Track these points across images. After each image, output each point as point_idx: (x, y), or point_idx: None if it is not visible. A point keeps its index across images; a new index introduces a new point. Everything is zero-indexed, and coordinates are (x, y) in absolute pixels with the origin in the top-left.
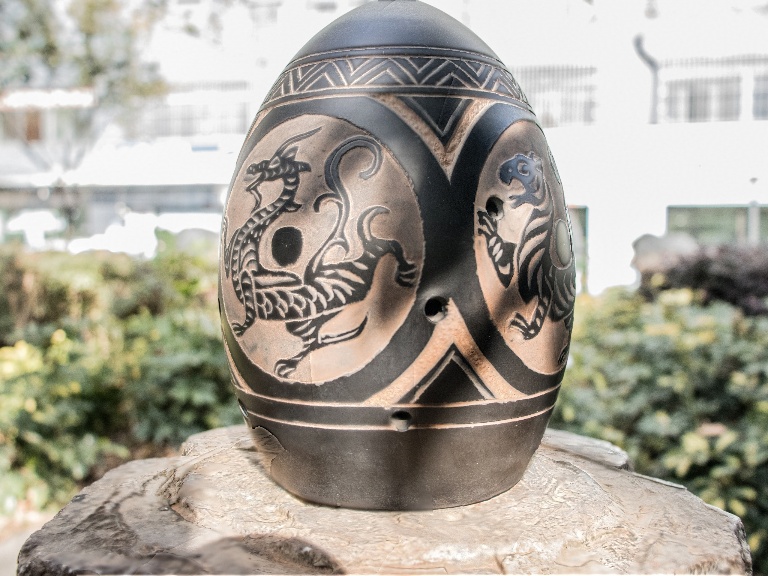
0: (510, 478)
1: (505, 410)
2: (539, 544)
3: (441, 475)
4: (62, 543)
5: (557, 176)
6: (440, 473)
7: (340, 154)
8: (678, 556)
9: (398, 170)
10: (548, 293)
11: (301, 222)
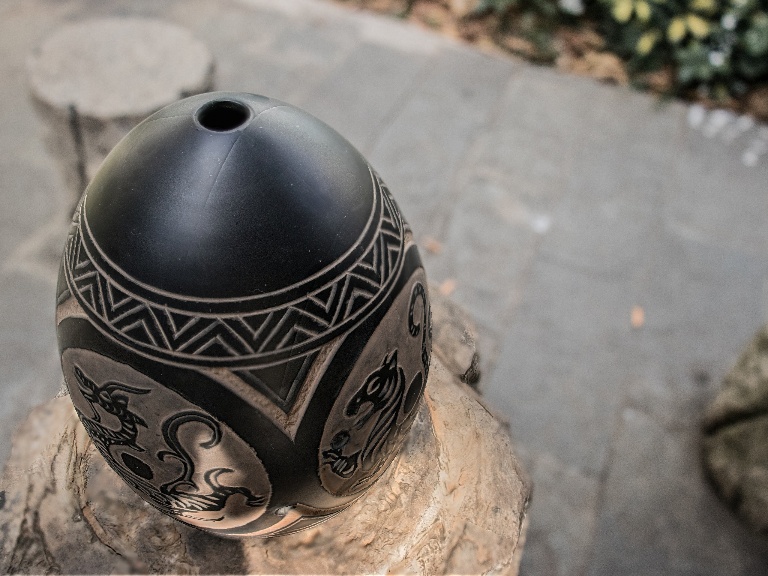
0: None
1: None
2: None
3: None
4: None
5: (416, 329)
6: None
7: (176, 424)
8: (467, 569)
9: (239, 442)
10: (392, 445)
11: (147, 461)
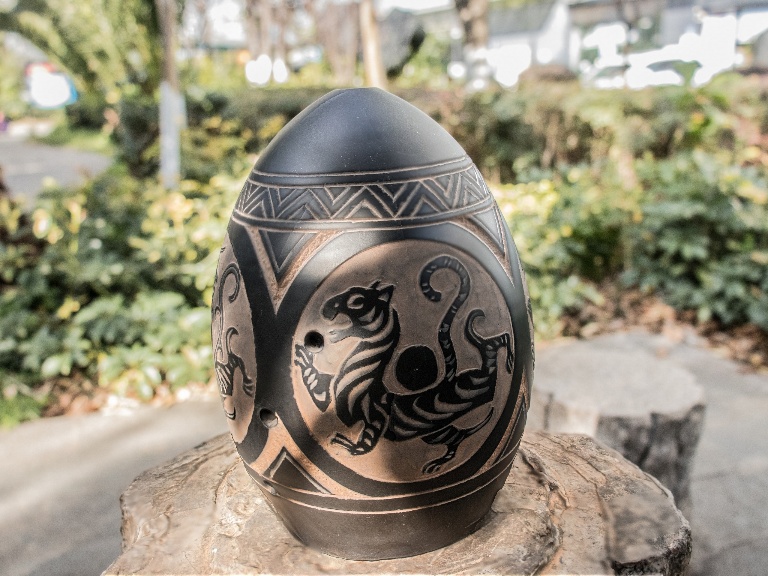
0: (393, 551)
1: (348, 504)
2: None
3: (315, 533)
4: (147, 483)
5: (434, 294)
6: (313, 531)
7: (225, 276)
8: None
9: (246, 300)
10: (381, 418)
11: None
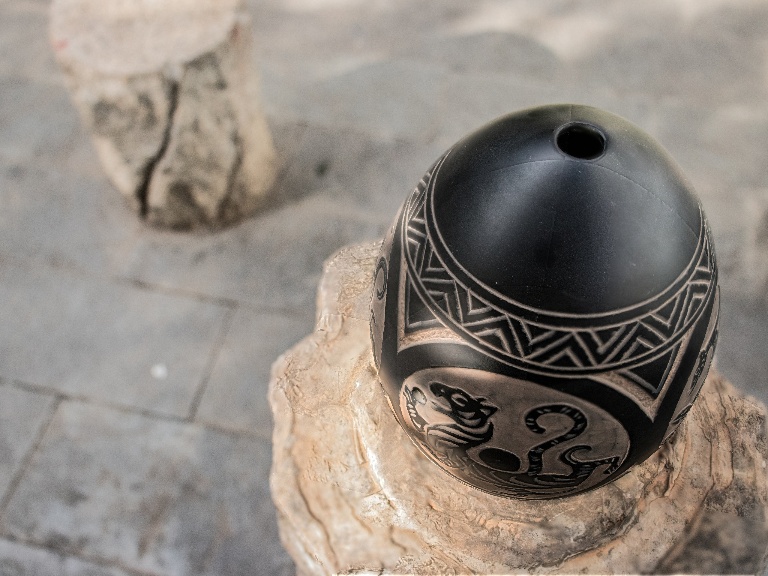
0: None
1: None
2: (404, 513)
3: None
4: (345, 265)
5: (537, 428)
6: None
7: None
8: None
9: (384, 313)
10: None
11: None
